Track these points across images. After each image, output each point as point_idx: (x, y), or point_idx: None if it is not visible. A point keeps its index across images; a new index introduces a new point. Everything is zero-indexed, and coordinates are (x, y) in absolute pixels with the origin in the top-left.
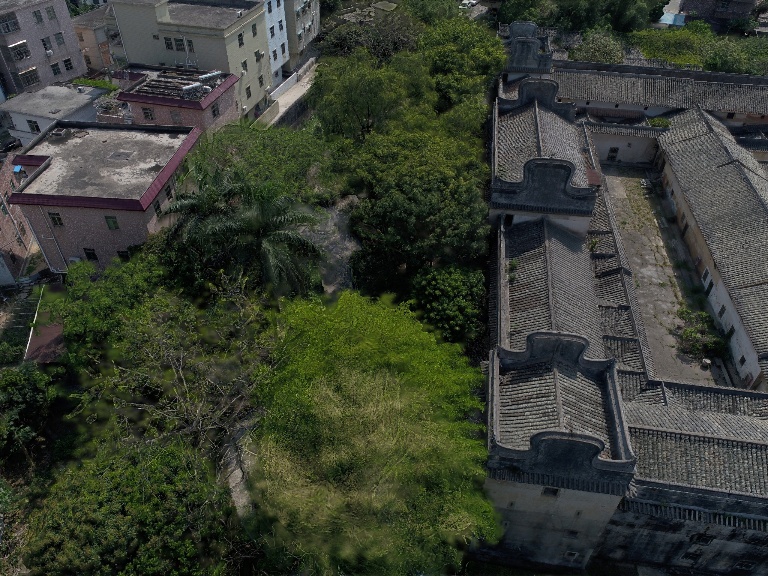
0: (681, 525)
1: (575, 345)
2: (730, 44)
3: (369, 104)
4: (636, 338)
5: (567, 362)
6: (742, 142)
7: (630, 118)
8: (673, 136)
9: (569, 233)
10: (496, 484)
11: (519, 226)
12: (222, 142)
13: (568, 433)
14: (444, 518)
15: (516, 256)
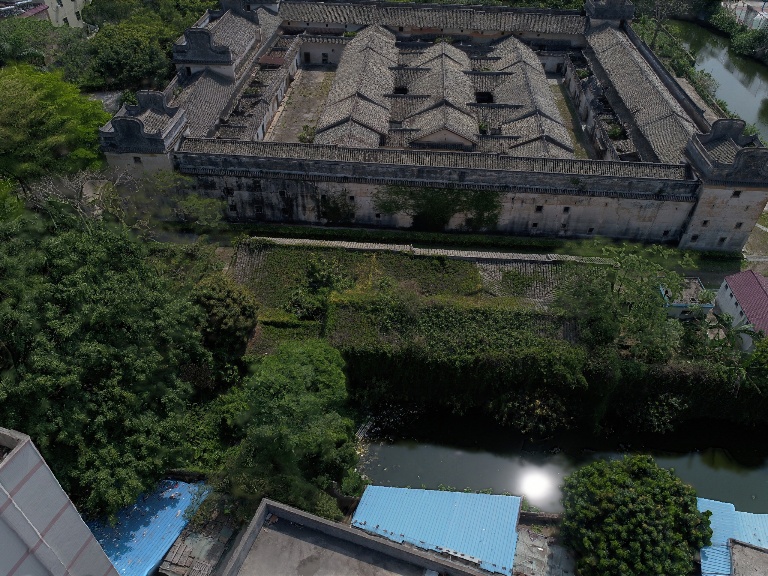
0: (214, 183)
1: (158, 97)
2: None
3: (112, 10)
4: (246, 126)
5: (159, 109)
6: (403, 45)
7: (336, 33)
8: (354, 41)
9: (225, 78)
10: (112, 159)
11: (195, 75)
12: (3, 24)
13: (124, 117)
14: (50, 138)
15: (185, 87)
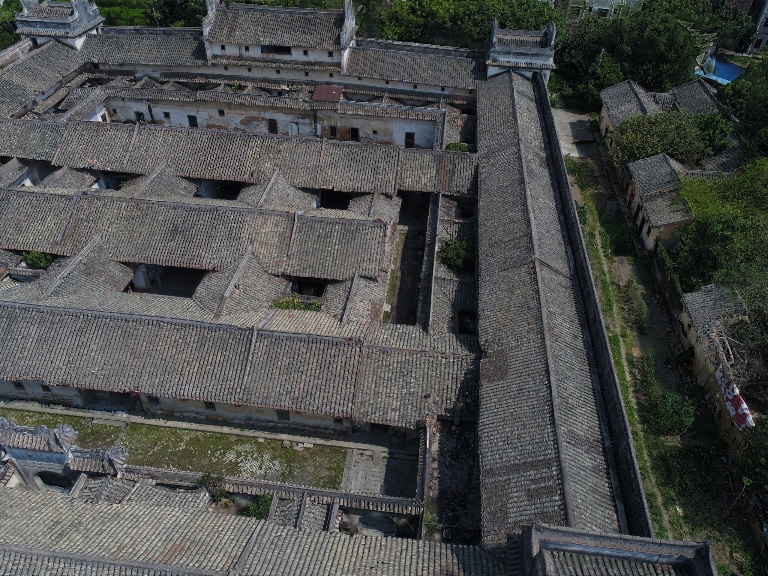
0: None
1: None
2: (760, 222)
3: None
4: None
5: None
6: None
7: None
8: None
9: None
10: None
11: None
12: None
13: None
14: None
15: None
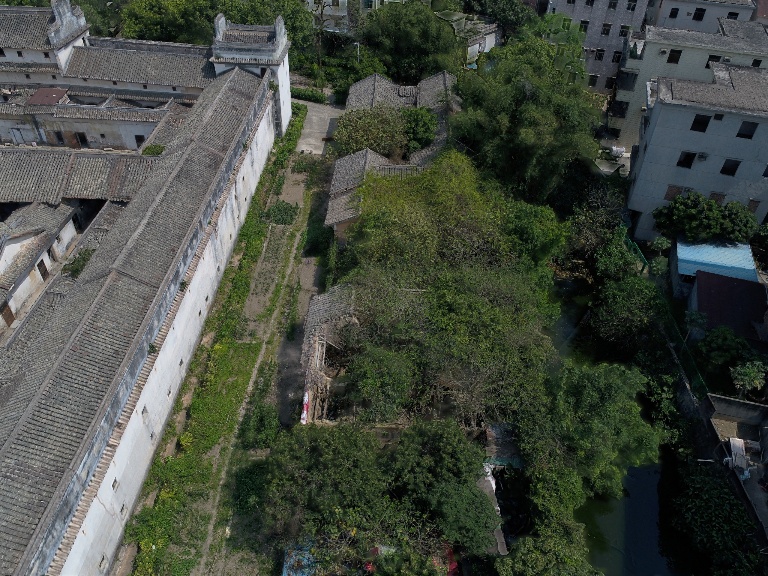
0: None
1: None
2: None
3: None
4: None
5: None
6: None
7: None
8: None
9: None
10: None
11: None
12: None
13: None
14: None
15: None
